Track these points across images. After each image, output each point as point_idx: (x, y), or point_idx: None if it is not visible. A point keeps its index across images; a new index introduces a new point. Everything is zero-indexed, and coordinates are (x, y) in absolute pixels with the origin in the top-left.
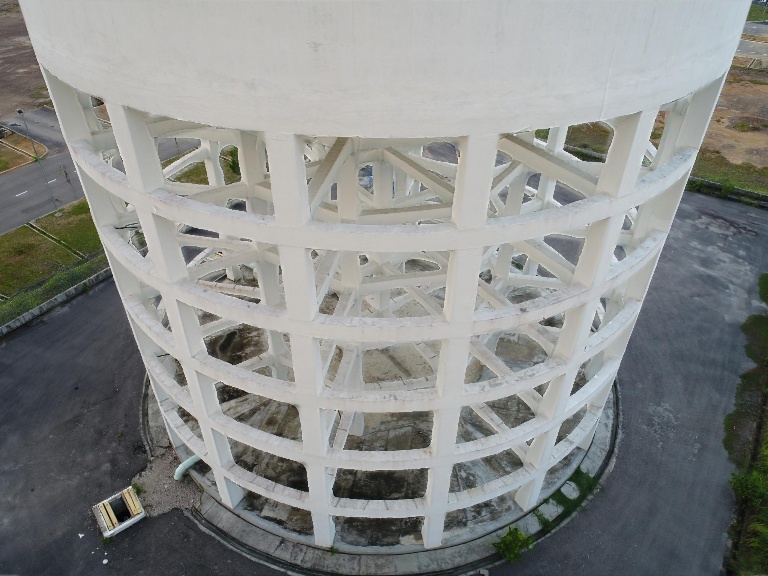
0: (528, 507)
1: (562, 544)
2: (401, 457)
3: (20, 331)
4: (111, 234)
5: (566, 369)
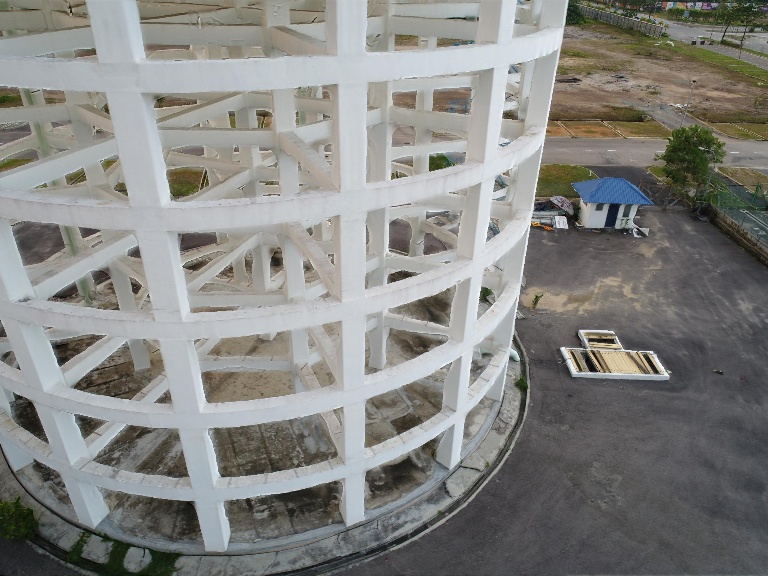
0: (82, 520)
1: None
2: None
3: None
4: None
5: None
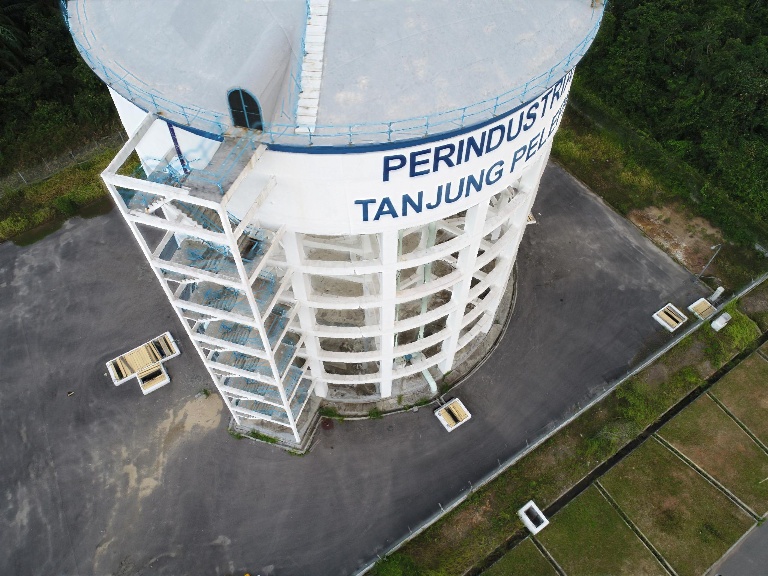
0: None
1: None
2: None
3: (622, 374)
4: None
5: None
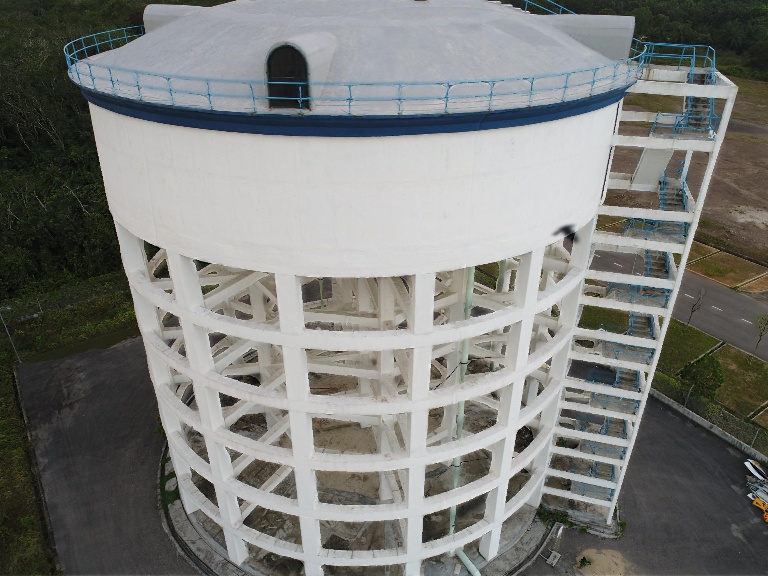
0: None
1: (150, 465)
2: None
3: None
4: None
5: None
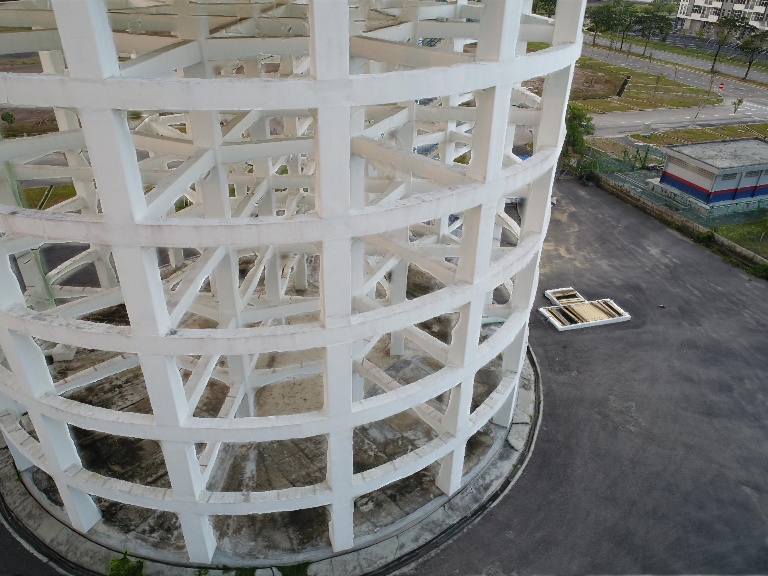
0: (194, 558)
1: None
2: (2, 376)
3: None
4: None
5: (134, 346)
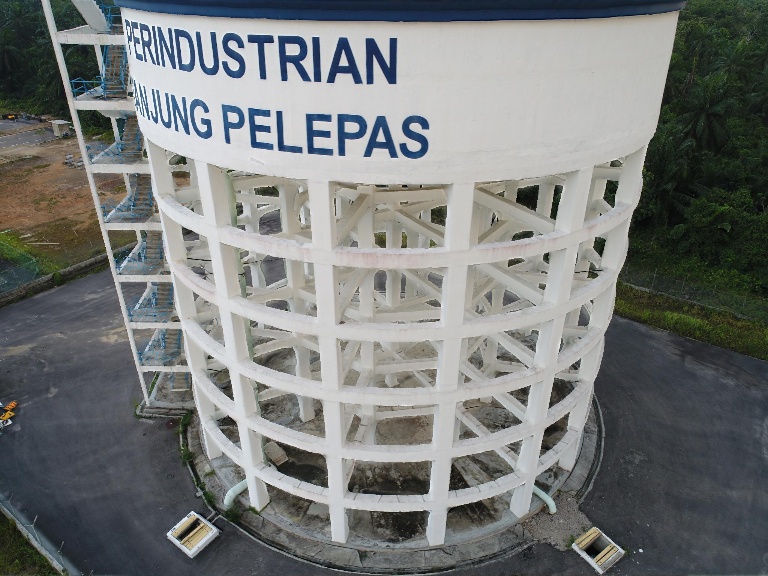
0: None
1: None
2: None
3: None
4: (575, 294)
5: None
